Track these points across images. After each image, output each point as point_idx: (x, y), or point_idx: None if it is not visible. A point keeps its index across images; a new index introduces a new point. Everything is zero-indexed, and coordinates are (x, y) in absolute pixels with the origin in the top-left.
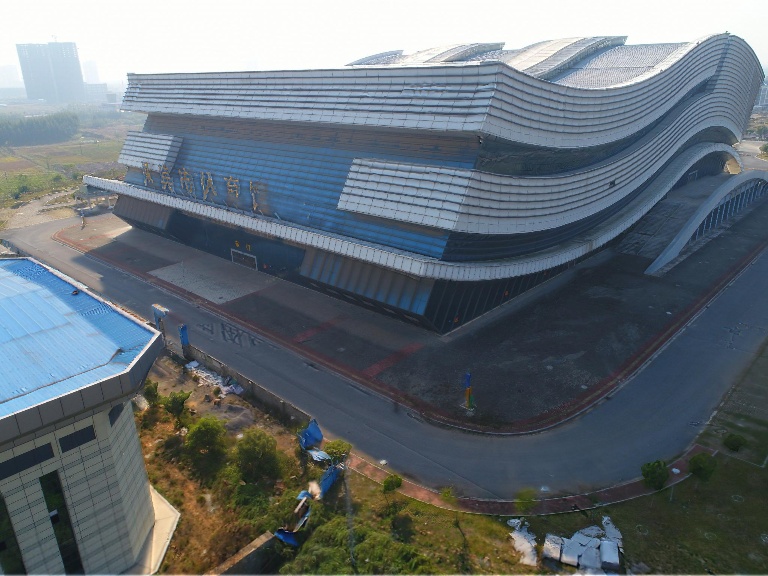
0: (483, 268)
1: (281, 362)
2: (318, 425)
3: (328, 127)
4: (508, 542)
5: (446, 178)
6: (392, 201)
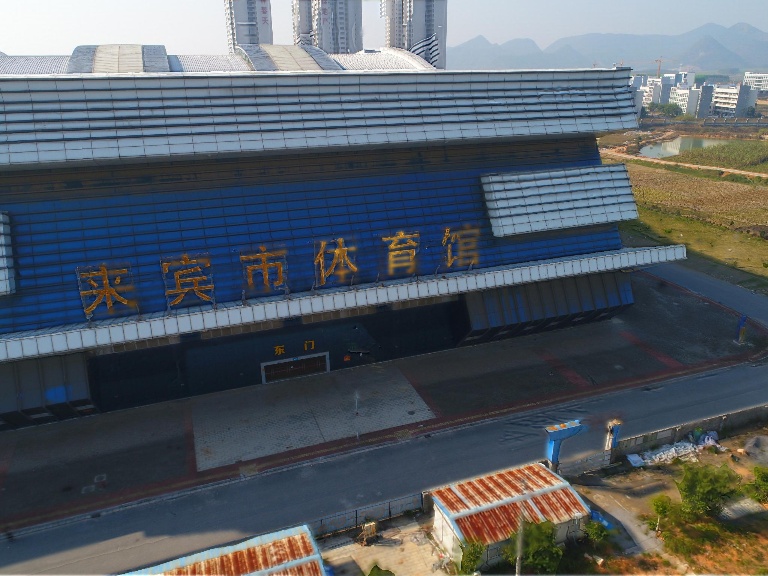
0: None
1: (639, 403)
2: None
3: (403, 147)
4: None
5: (607, 175)
6: (570, 209)
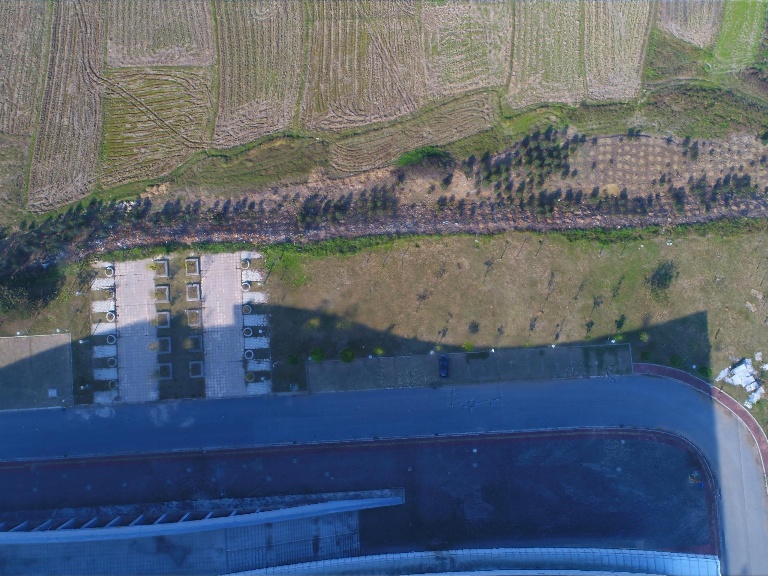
0: (635, 554)
1: None
2: (765, 527)
3: None
4: (760, 402)
5: None
6: None
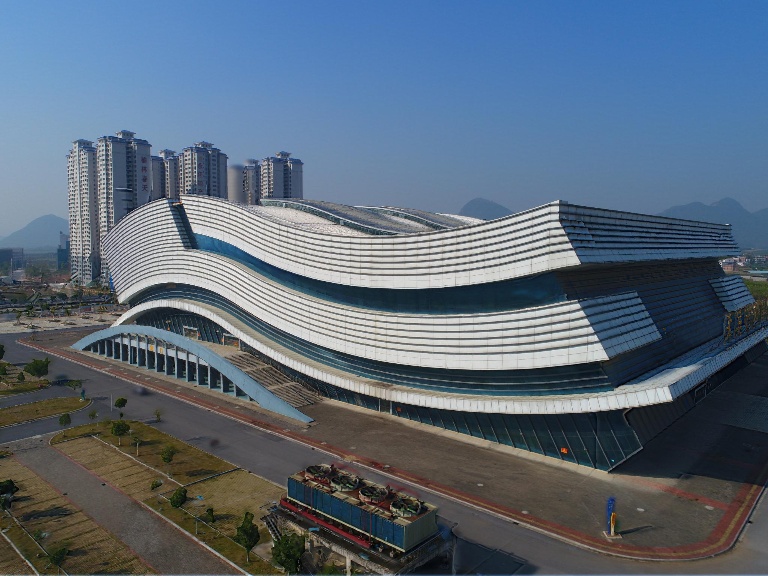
0: None
1: None
2: None
3: None
4: None
5: None
6: None
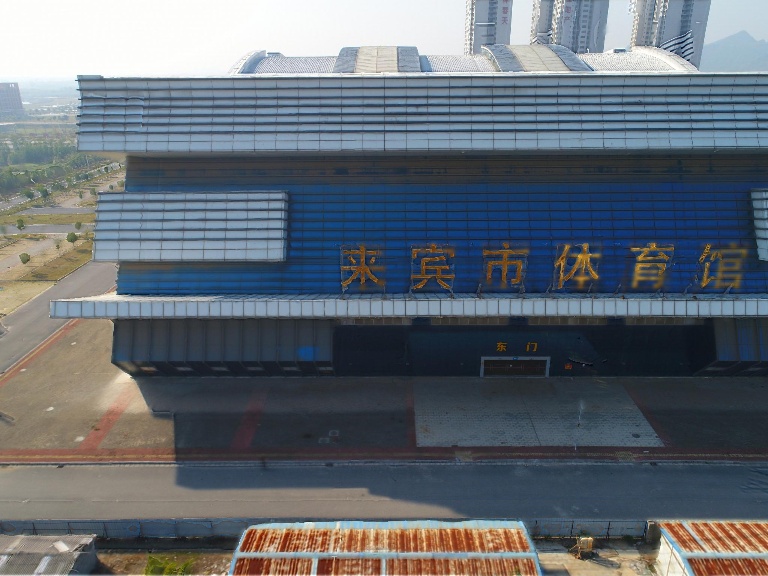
0: None
1: None
2: None
3: (662, 154)
4: None
5: None
6: None
